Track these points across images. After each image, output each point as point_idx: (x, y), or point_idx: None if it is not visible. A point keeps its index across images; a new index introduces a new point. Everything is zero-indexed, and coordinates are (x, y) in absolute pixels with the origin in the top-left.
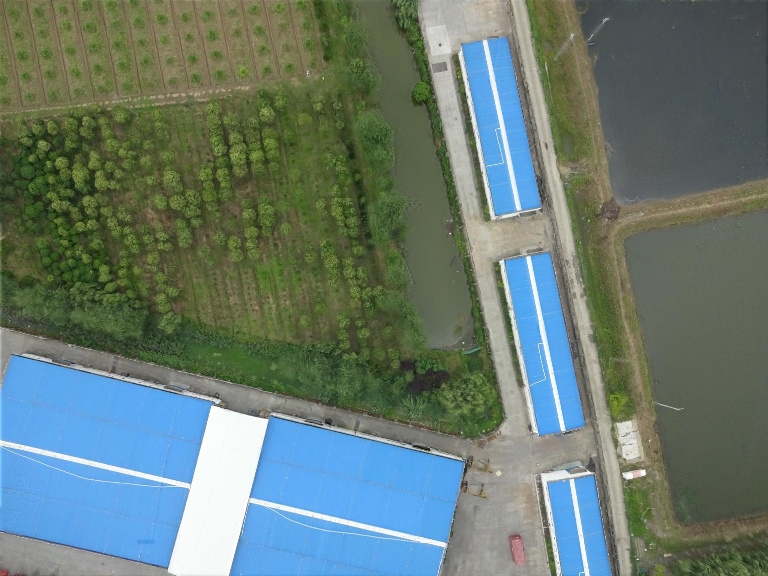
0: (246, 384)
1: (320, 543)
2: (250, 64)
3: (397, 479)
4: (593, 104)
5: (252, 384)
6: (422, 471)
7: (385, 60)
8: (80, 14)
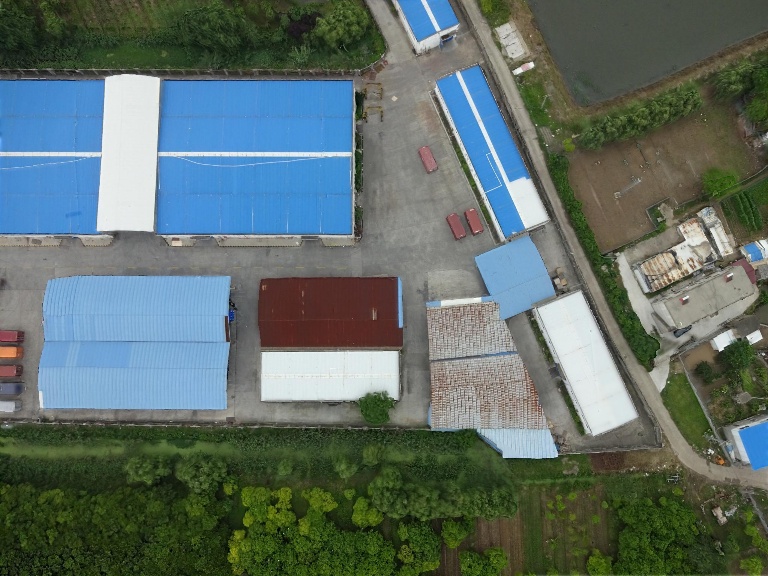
0: None
1: (234, 180)
2: None
3: (293, 108)
4: None
5: None
6: (315, 97)
7: None
8: None
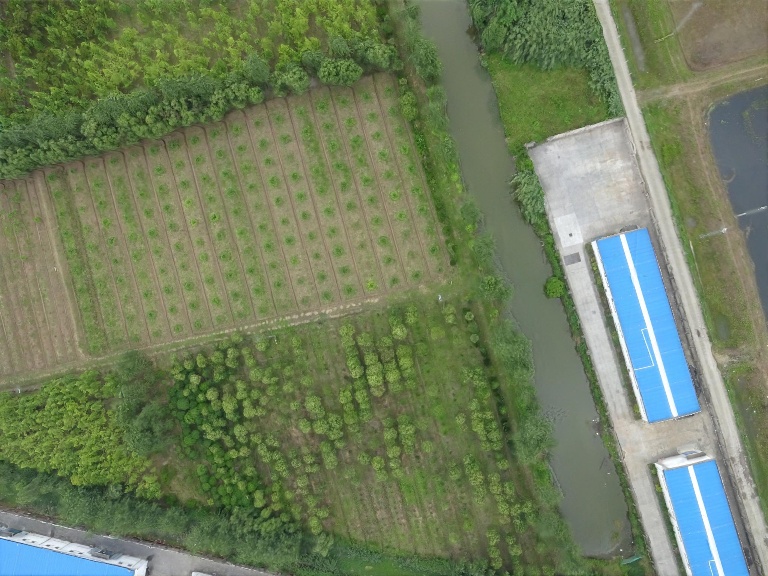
0: None
1: None
2: (377, 275)
3: None
4: (750, 282)
5: None
6: None
7: (514, 262)
8: (215, 243)
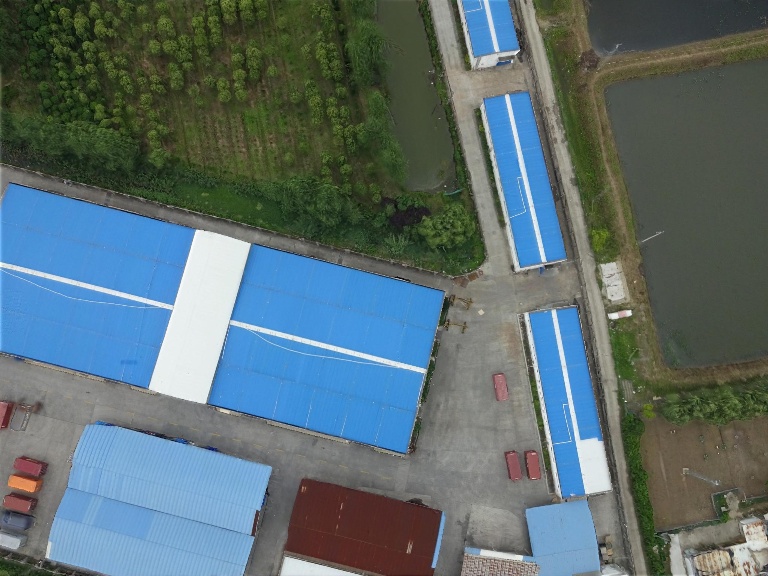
0: (232, 220)
1: (300, 367)
2: None
3: (377, 306)
4: None
5: (238, 221)
6: (402, 300)
7: None
8: None
